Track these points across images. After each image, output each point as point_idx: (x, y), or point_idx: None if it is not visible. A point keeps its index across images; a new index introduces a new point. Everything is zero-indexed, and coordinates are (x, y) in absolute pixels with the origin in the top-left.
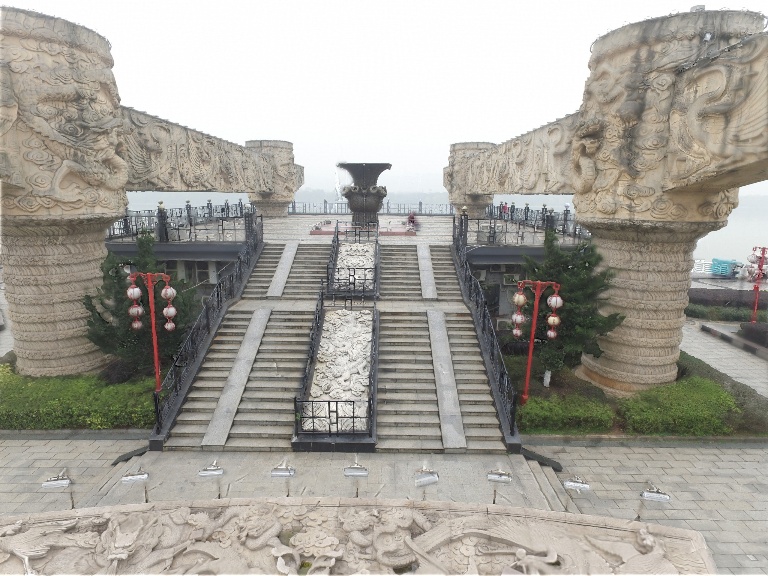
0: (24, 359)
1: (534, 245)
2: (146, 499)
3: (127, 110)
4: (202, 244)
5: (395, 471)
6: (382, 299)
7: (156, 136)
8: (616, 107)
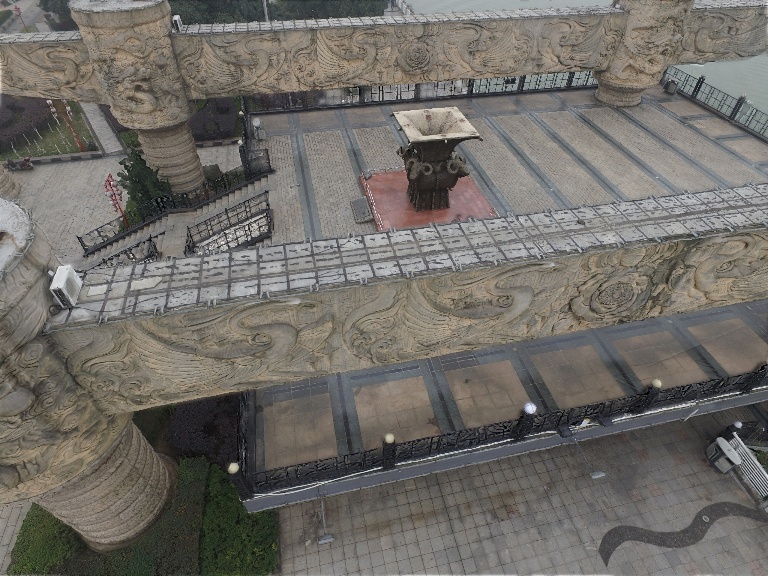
0: None
1: None
2: None
3: (208, 36)
4: None
5: None
6: None
7: (252, 49)
8: None
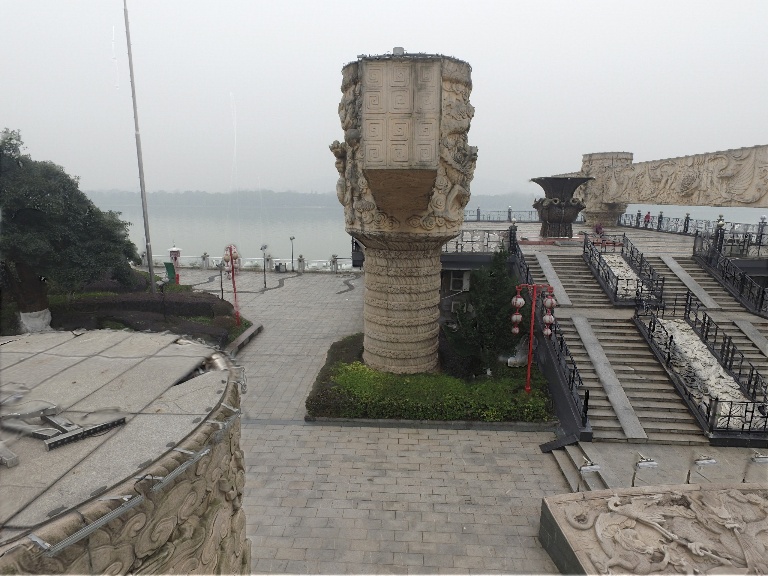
0: (386, 358)
1: None
2: (688, 481)
3: None
4: (468, 255)
5: None
6: (668, 308)
7: None
8: None
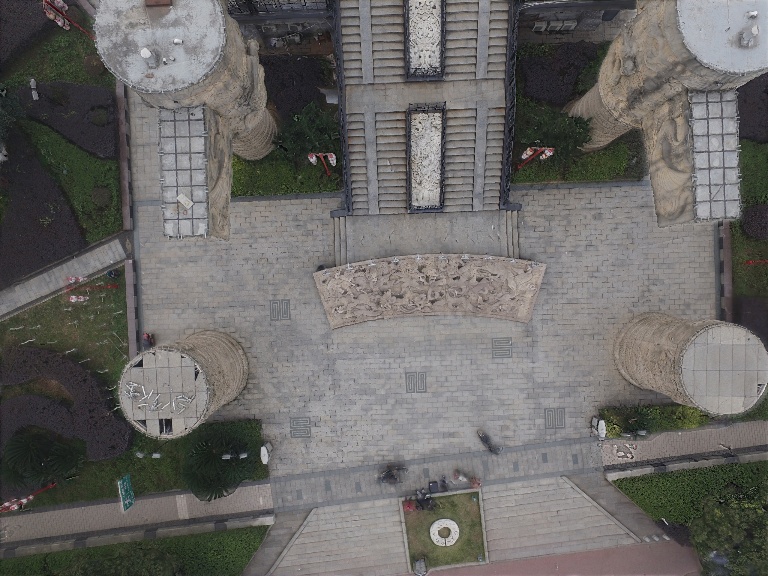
0: None
1: (585, 0)
2: None
3: None
4: (289, 14)
5: (452, 225)
6: (446, 81)
7: None
8: (647, 73)
